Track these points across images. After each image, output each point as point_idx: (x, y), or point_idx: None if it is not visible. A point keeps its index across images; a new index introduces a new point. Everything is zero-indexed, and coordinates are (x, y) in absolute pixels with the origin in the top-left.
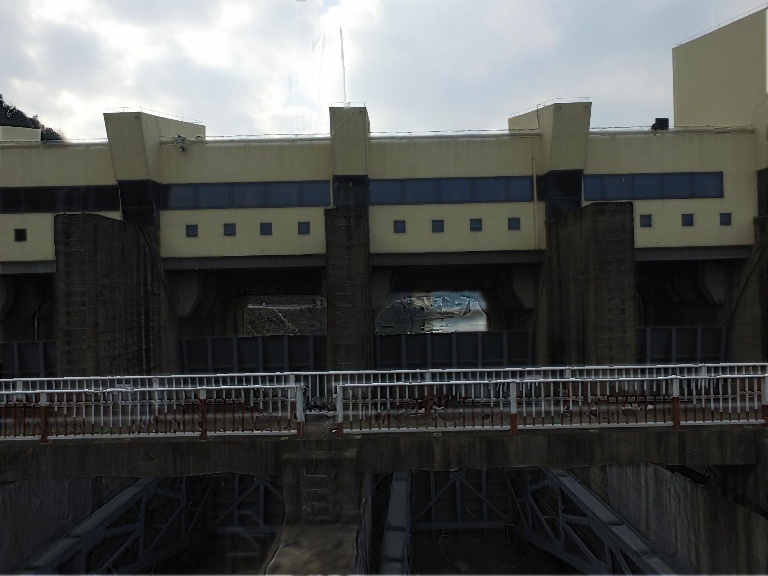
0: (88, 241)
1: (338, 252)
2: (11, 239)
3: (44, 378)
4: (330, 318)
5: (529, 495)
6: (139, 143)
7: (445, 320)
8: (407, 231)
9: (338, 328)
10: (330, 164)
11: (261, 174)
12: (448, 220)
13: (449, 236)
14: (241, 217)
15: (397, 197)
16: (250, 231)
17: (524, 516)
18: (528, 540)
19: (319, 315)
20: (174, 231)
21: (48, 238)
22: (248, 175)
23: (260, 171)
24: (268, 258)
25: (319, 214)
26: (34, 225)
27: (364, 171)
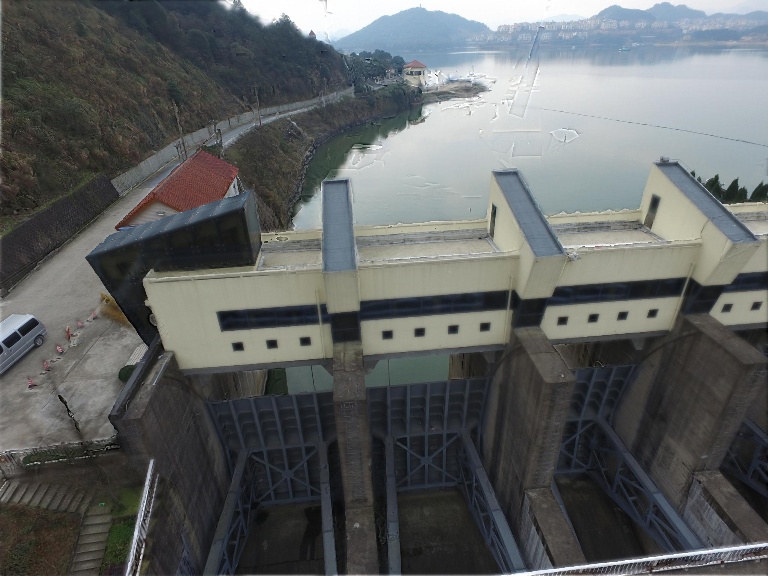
0: (568, 398)
1: (742, 390)
2: (411, 336)
3: (670, 557)
4: (719, 425)
5: (756, 464)
6: (555, 276)
7: (443, 103)
8: (731, 311)
9: (722, 430)
10: (692, 266)
11: (630, 275)
12: (766, 301)
13: (761, 312)
14: (605, 309)
15: (733, 286)
16: (609, 318)
17: (740, 467)
18: (742, 481)
19: (326, 115)
20: (548, 322)
21: (442, 333)
22: (619, 277)
23: (630, 273)
24: (616, 335)
25: (668, 303)
26: (431, 325)
27: (729, 282)
